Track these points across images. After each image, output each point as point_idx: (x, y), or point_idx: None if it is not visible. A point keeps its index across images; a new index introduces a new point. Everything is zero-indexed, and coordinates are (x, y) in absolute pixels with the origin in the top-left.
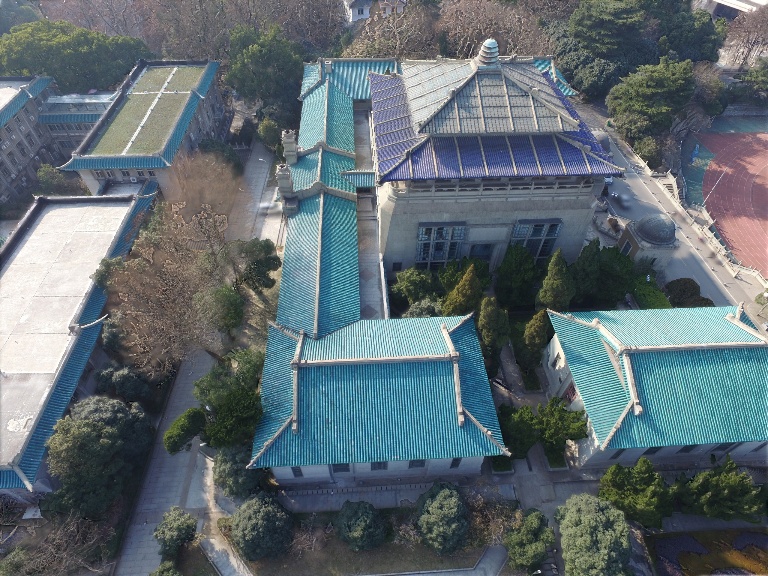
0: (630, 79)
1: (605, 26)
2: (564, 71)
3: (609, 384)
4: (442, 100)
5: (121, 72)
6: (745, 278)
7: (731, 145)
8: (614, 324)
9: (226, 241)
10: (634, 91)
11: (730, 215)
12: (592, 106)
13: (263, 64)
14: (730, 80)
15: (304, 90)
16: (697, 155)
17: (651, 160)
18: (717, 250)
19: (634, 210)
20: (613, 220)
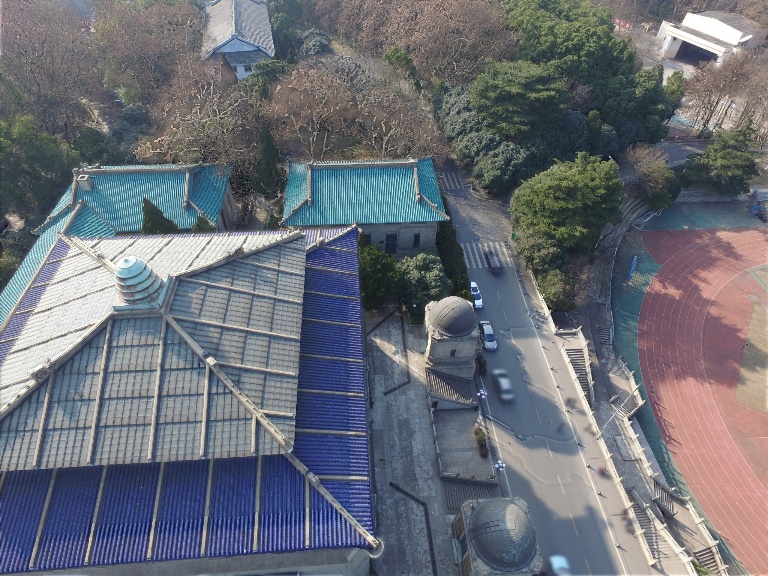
0: (536, 183)
1: (515, 100)
2: (464, 156)
3: None
4: (31, 379)
5: None
6: (668, 567)
7: (682, 250)
8: None
9: None
10: (539, 202)
11: (671, 375)
12: (499, 203)
13: (8, 171)
14: (687, 151)
15: None
16: (637, 267)
17: (559, 304)
18: (628, 503)
19: (518, 405)
20: (478, 435)
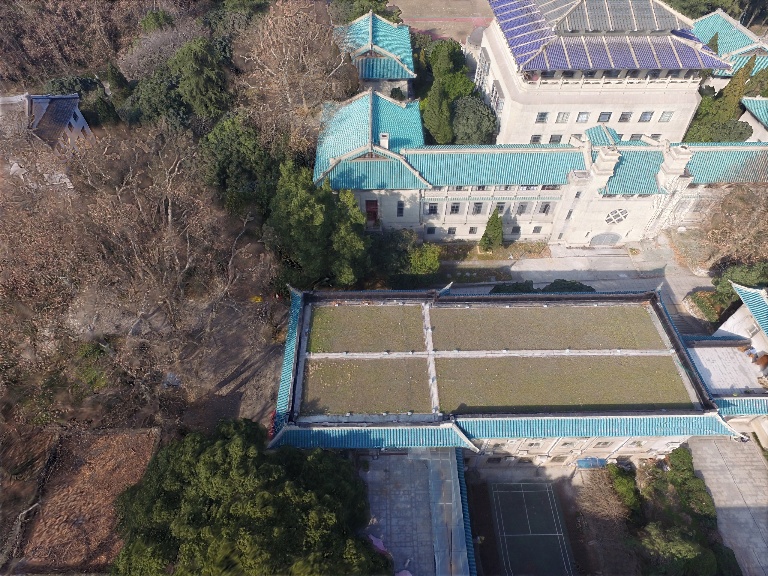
0: (359, 8)
1: None
2: None
3: (766, 61)
4: (654, 6)
5: (339, 458)
6: None
7: None
8: (720, 52)
9: (764, 213)
10: None
11: None
12: None
13: None
14: None
15: (406, 183)
16: None
17: None
18: None
19: None
20: None
